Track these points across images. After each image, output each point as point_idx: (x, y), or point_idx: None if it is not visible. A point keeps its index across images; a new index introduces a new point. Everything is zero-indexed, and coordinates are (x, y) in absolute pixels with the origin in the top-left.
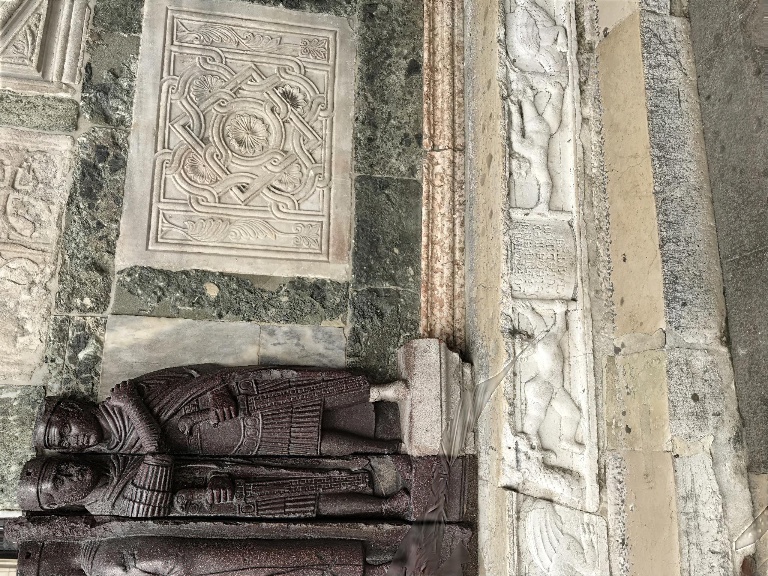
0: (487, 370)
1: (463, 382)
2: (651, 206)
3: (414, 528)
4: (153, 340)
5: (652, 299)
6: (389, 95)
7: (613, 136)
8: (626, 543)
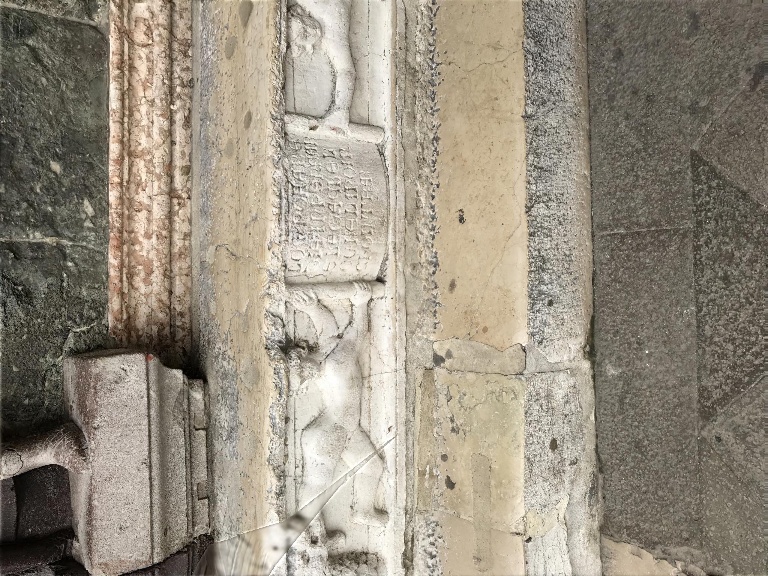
0: (235, 403)
1: (189, 416)
2: (518, 139)
3: None
4: None
5: (508, 294)
6: None
7: (455, 2)
8: None
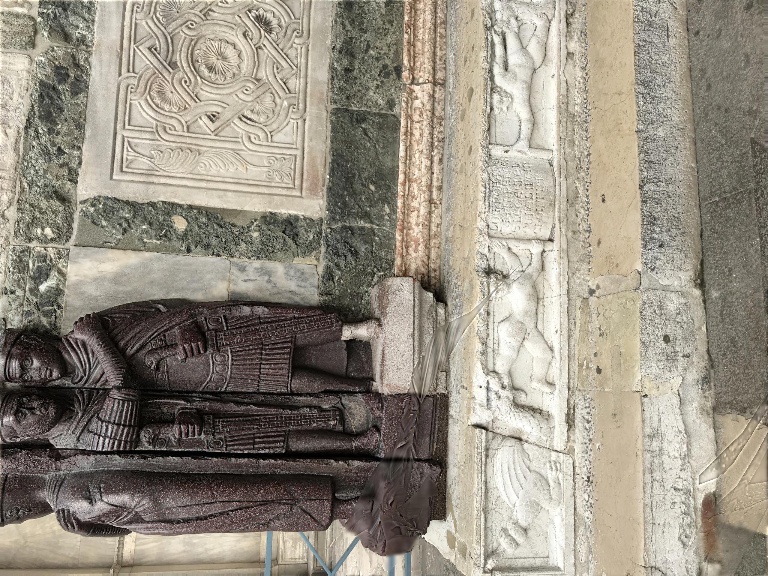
0: (461, 310)
1: (436, 322)
2: (633, 145)
3: (383, 463)
4: (118, 273)
5: (629, 240)
6: (368, 23)
7: (598, 72)
8: (591, 480)
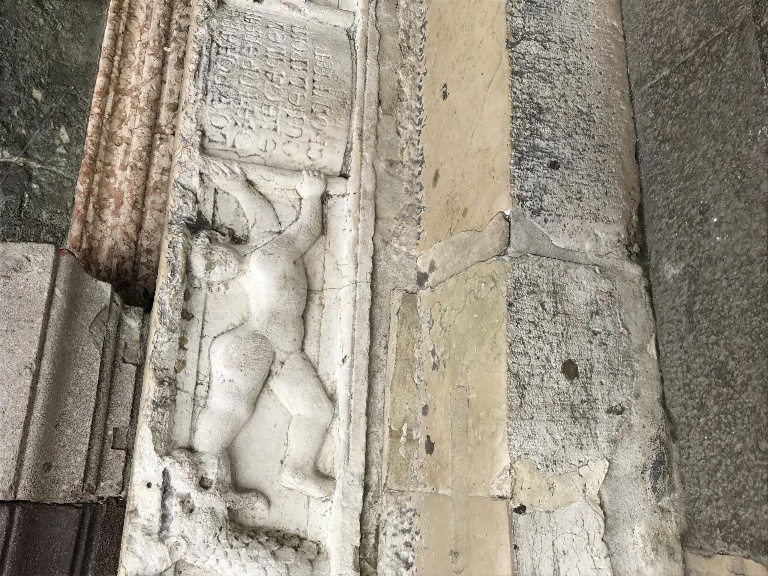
0: None
1: (118, 344)
2: None
3: None
4: None
5: (487, 153)
6: None
7: None
8: None
